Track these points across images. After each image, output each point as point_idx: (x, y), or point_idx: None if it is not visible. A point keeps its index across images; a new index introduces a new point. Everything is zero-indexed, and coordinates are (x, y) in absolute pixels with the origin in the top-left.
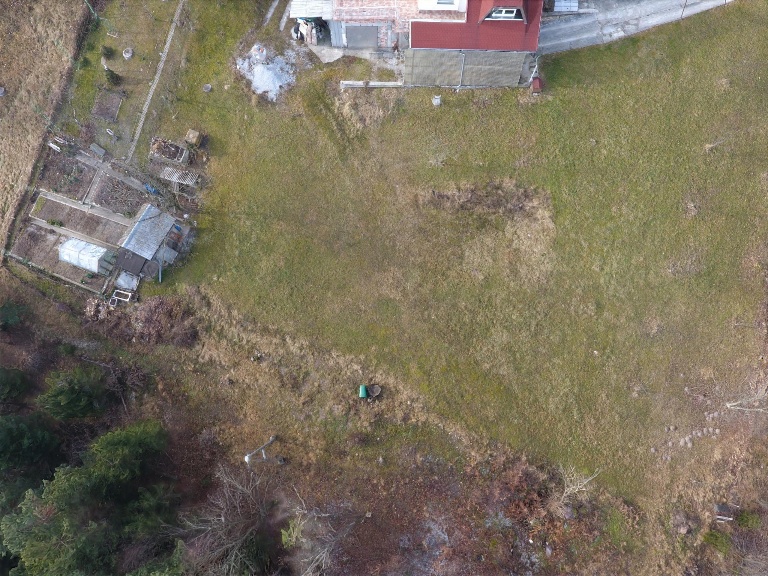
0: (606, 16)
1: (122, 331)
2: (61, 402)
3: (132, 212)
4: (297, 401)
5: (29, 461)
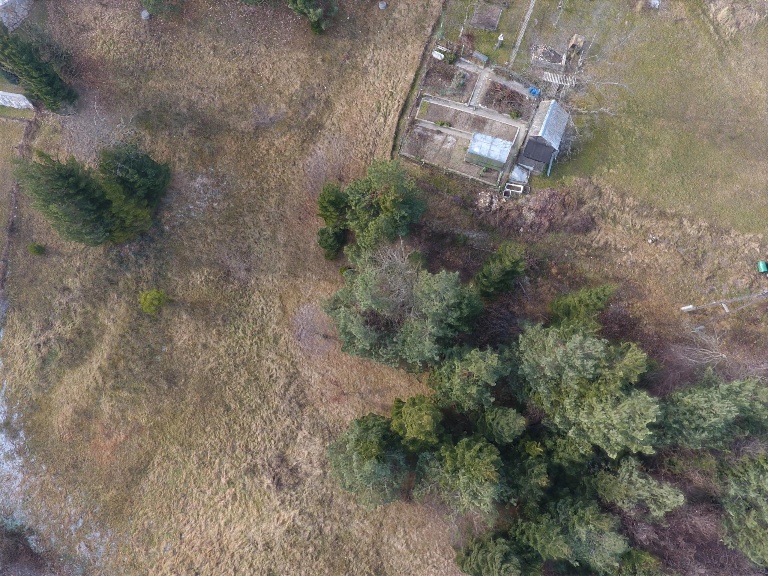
0: None
1: (513, 221)
2: (521, 268)
3: (518, 112)
4: (700, 277)
5: (472, 328)
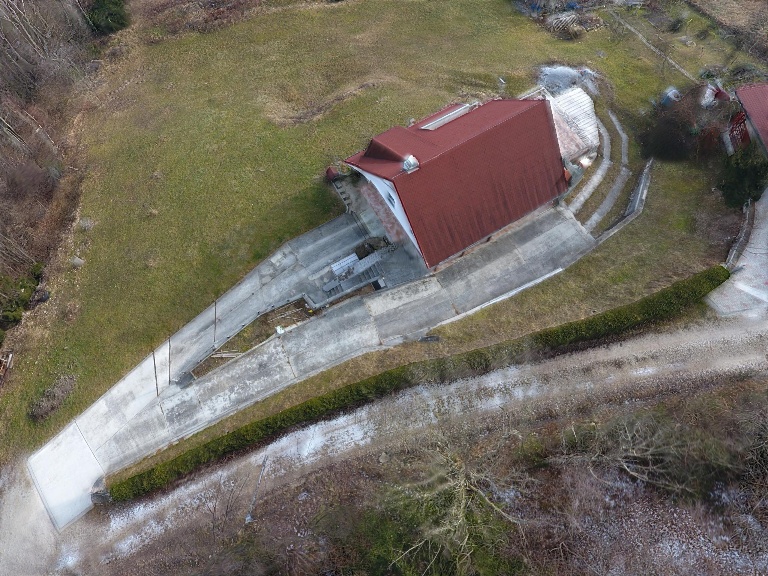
0: (298, 276)
1: None
2: None
3: None
4: None
5: None
